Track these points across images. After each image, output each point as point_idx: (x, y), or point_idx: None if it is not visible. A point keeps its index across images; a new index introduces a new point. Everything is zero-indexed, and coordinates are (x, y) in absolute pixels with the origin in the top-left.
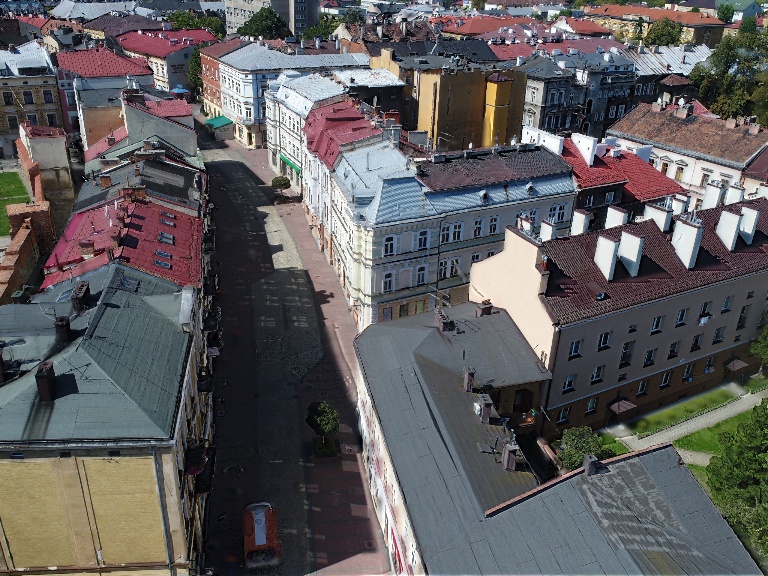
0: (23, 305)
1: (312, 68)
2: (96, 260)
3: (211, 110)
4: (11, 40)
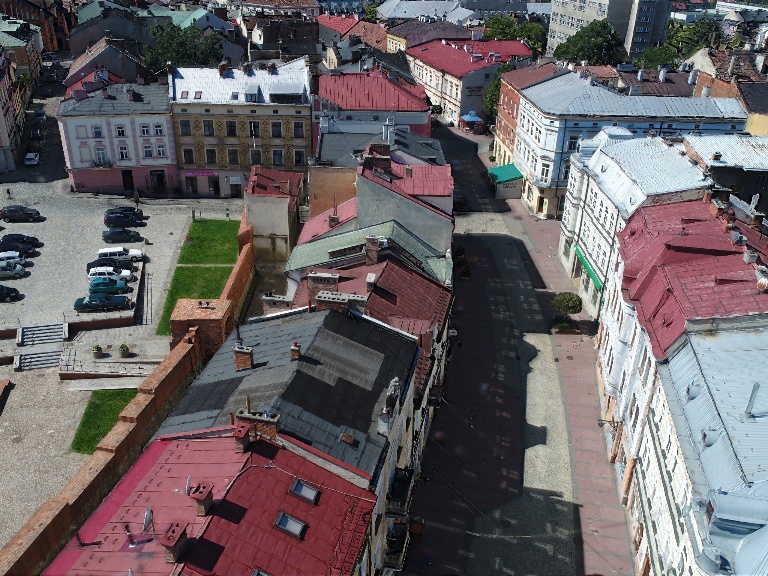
0: None
1: (649, 117)
2: None
3: (500, 152)
4: (298, 49)
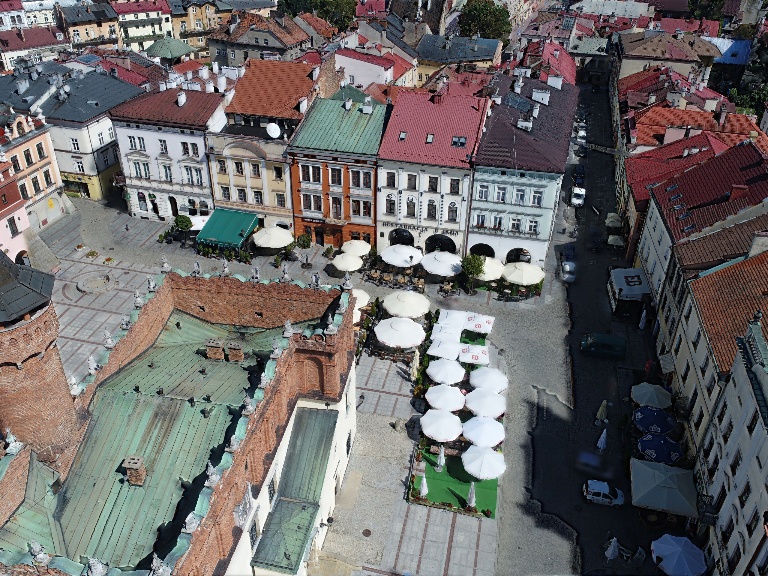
0: (193, 1)
1: None
2: (160, 4)
3: None
4: None
